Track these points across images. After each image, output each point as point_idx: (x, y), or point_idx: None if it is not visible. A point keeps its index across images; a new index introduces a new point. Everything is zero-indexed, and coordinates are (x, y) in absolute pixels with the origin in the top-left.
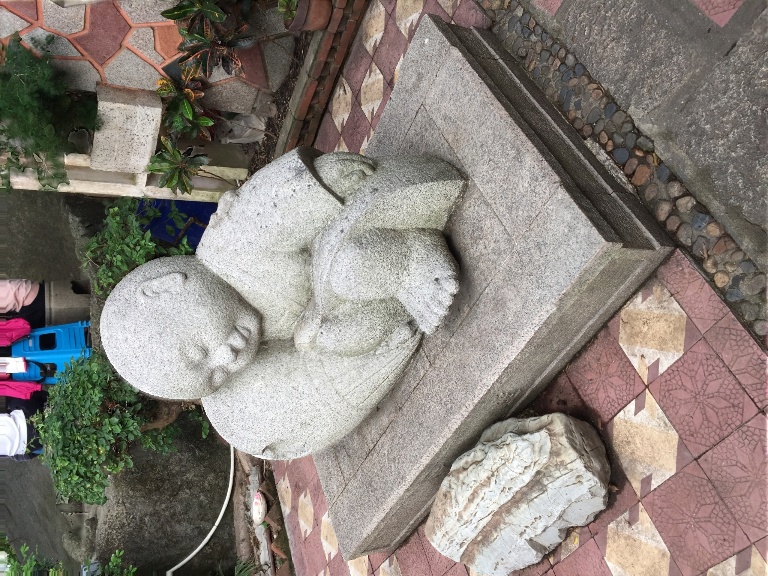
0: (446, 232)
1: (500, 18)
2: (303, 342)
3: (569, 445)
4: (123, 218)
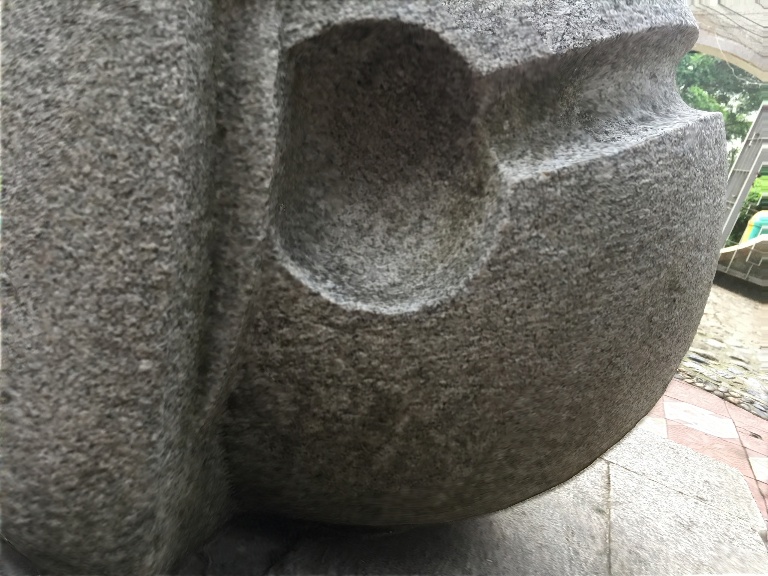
0: None
1: None
2: None
3: None
4: None
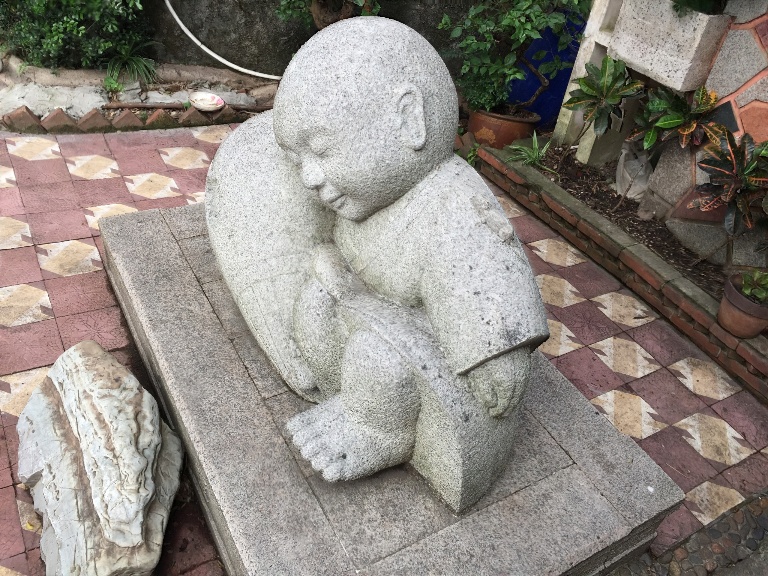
0: (408, 464)
1: (658, 569)
2: (318, 262)
3: (115, 570)
4: (563, 8)
